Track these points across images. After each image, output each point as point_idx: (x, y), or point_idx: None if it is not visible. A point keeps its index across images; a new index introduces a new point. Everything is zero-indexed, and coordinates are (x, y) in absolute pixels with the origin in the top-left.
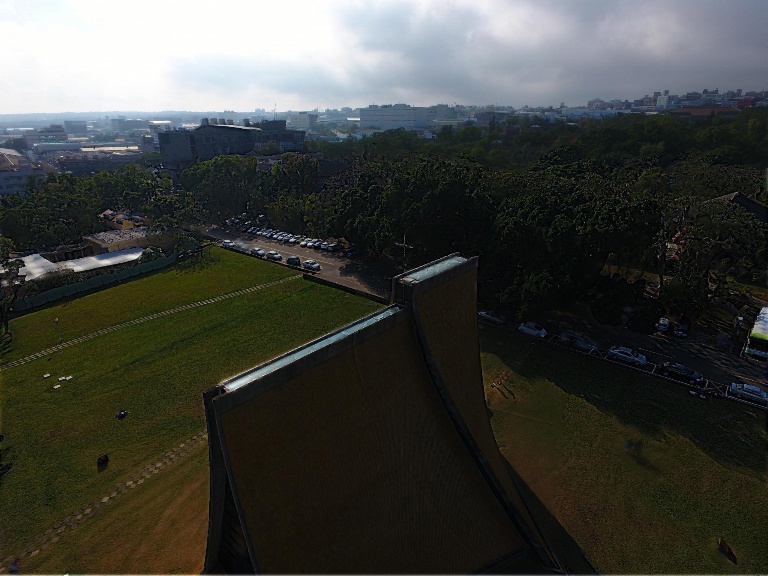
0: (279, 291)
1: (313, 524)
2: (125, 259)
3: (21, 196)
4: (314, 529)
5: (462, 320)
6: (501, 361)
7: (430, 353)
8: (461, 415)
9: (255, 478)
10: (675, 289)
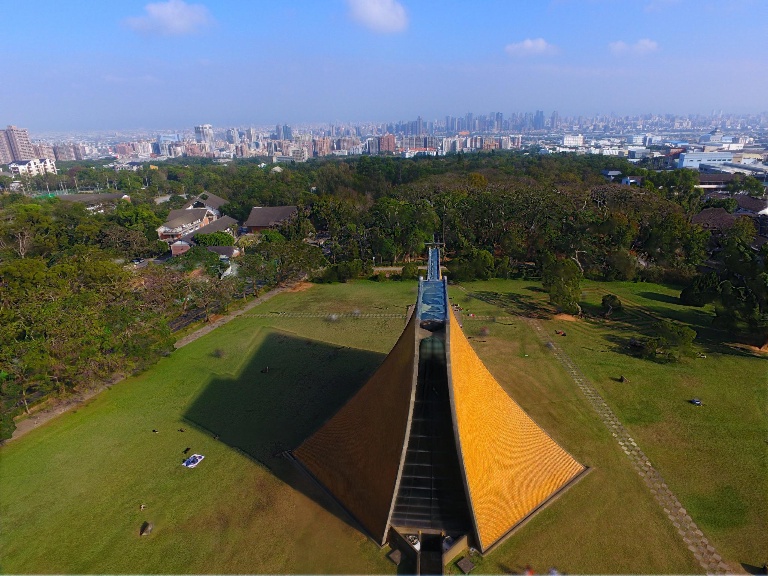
0: None
1: None
2: None
3: None
4: None
5: None
6: None
7: None
8: (371, 378)
9: None
10: None
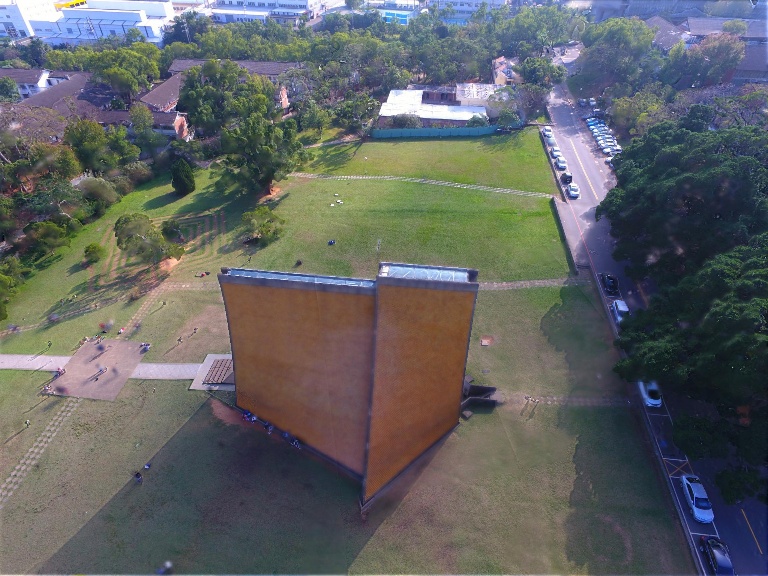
0: (515, 203)
1: (263, 360)
2: (462, 117)
3: (458, 26)
4: (263, 362)
5: (438, 324)
6: (571, 389)
7: (375, 327)
8: (374, 379)
9: (238, 319)
10: None
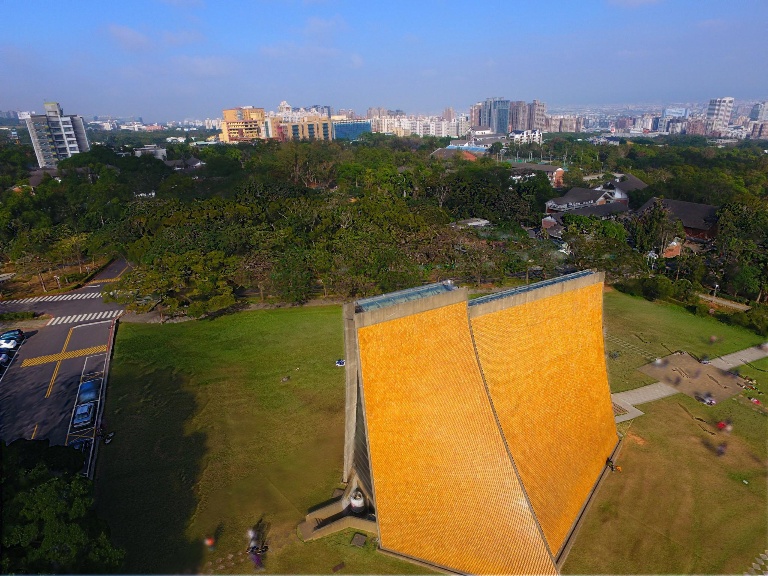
0: None
1: None
2: None
3: None
4: None
5: None
6: None
7: None
8: None
9: None
10: None
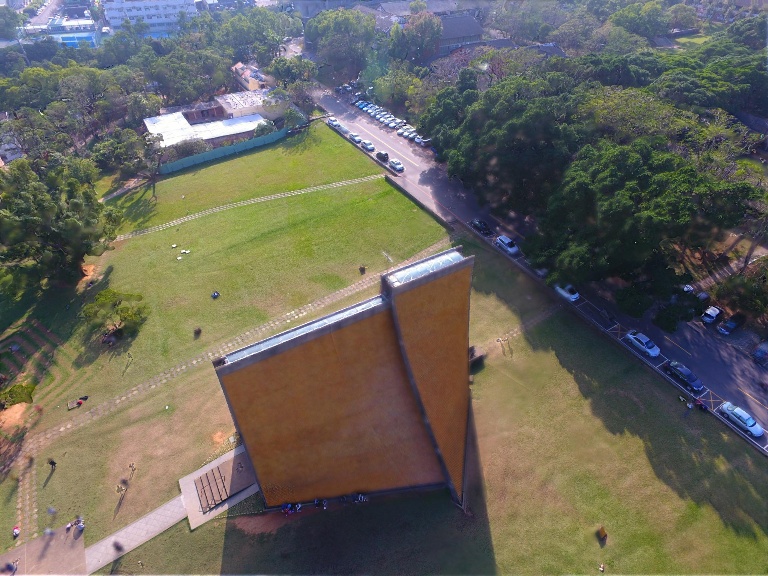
0: (359, 191)
1: (288, 437)
2: (245, 128)
3: (172, 39)
4: (288, 440)
5: (447, 308)
6: (520, 317)
7: (401, 338)
8: (417, 387)
9: (247, 409)
10: (736, 286)
